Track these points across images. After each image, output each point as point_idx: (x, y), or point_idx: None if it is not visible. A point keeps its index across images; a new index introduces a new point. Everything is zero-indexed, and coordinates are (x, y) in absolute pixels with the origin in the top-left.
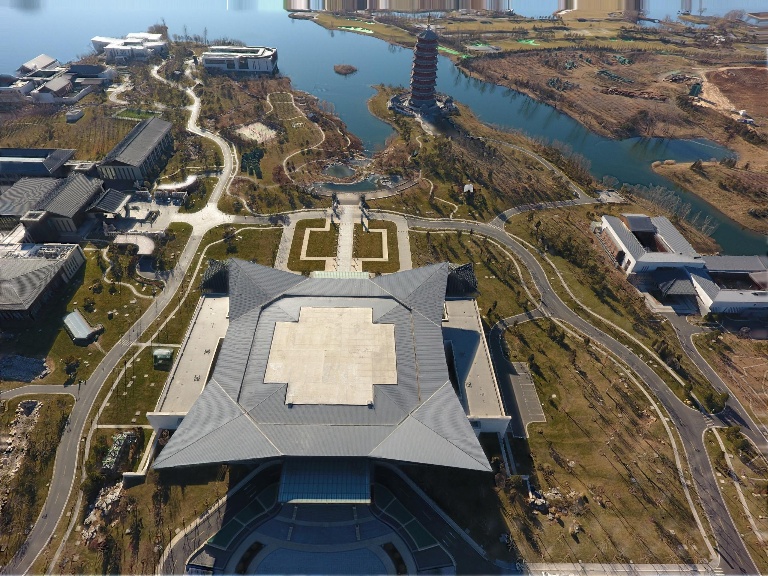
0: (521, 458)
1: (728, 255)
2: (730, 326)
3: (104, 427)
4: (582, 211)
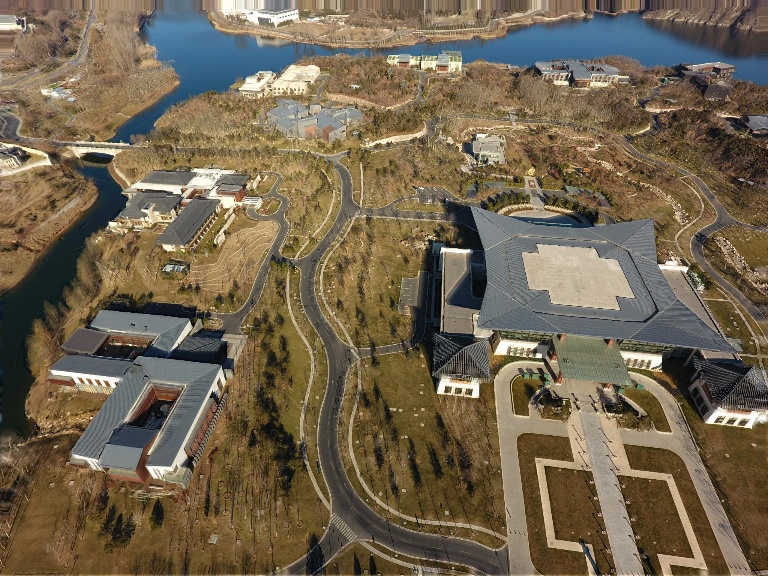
0: (429, 262)
1: (14, 436)
2: (189, 316)
3: (722, 300)
4: (150, 551)
